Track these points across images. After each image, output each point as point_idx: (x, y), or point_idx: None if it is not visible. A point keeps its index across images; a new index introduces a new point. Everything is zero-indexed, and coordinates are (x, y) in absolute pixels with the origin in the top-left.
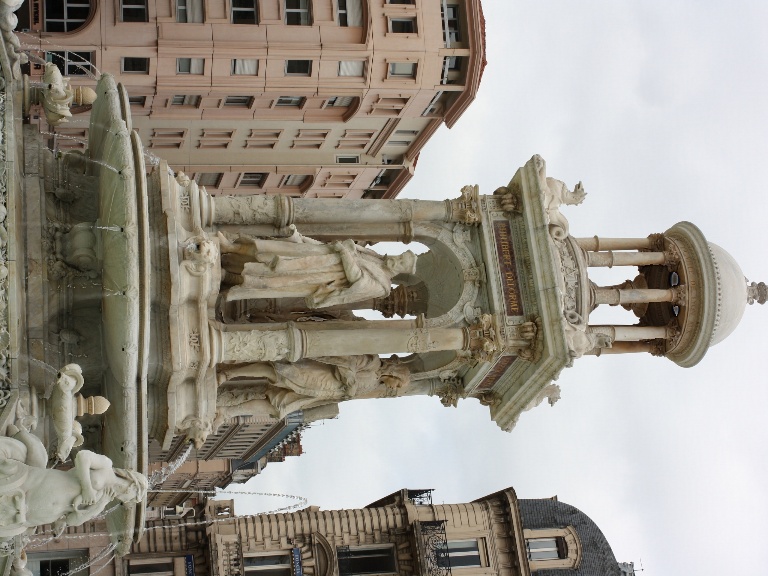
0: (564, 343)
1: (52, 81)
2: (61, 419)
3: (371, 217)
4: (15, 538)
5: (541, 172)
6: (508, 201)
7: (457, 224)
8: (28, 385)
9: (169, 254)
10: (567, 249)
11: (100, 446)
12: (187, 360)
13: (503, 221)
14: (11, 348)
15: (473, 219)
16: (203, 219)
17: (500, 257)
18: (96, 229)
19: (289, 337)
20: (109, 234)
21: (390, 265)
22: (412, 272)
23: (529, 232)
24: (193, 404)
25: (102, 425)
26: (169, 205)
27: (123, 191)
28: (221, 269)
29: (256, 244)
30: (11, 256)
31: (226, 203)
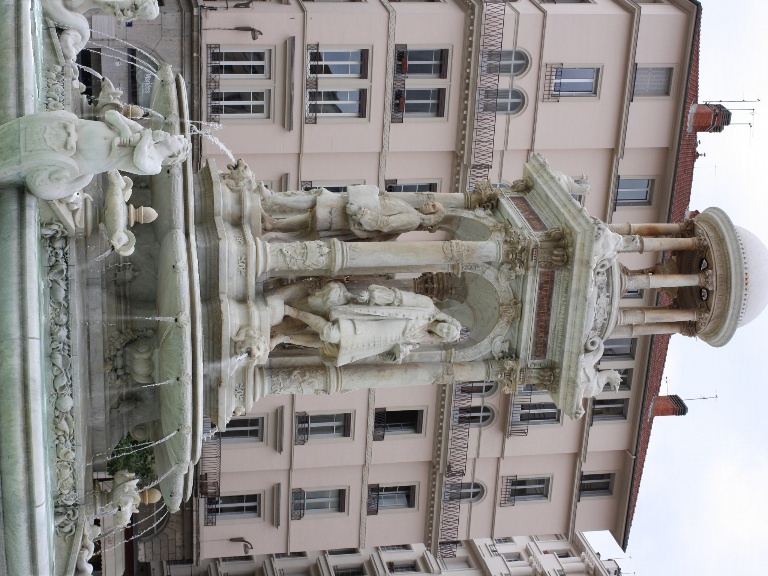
0: None
1: None
2: None
3: None
4: (65, 94)
5: None
6: None
7: None
8: None
9: None
10: None
11: None
12: None
13: None
14: None
15: None
16: None
17: None
18: None
19: None
20: None
21: None
22: None
23: None
24: None
25: None
26: None
27: None
28: None
29: None
30: None
31: None
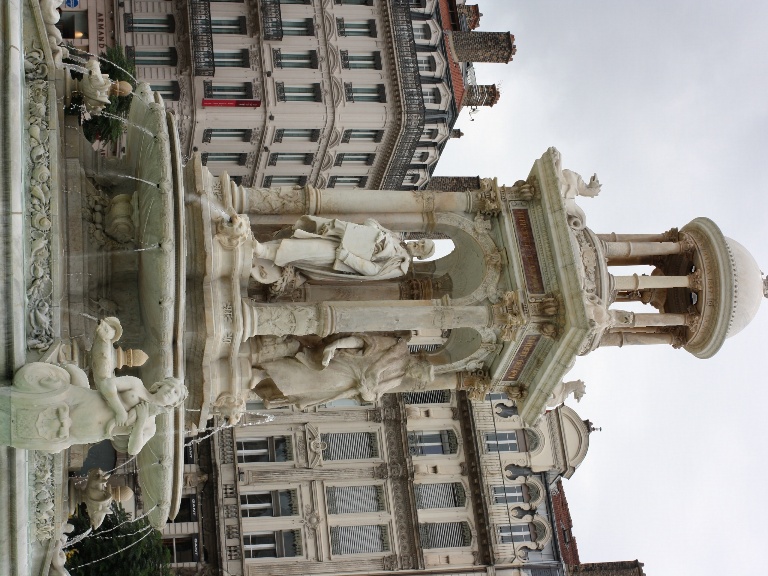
0: (534, 420)
1: None
2: None
3: None
4: None
5: None
6: (547, 334)
7: None
8: (68, 498)
9: (200, 419)
10: None
11: None
12: None
13: (536, 335)
14: None
15: None
16: None
17: (518, 353)
18: None
19: None
20: None
21: None
22: None
23: (551, 360)
24: None
25: None
26: None
27: (159, 515)
28: None
29: None
30: (57, 521)
31: (268, 332)
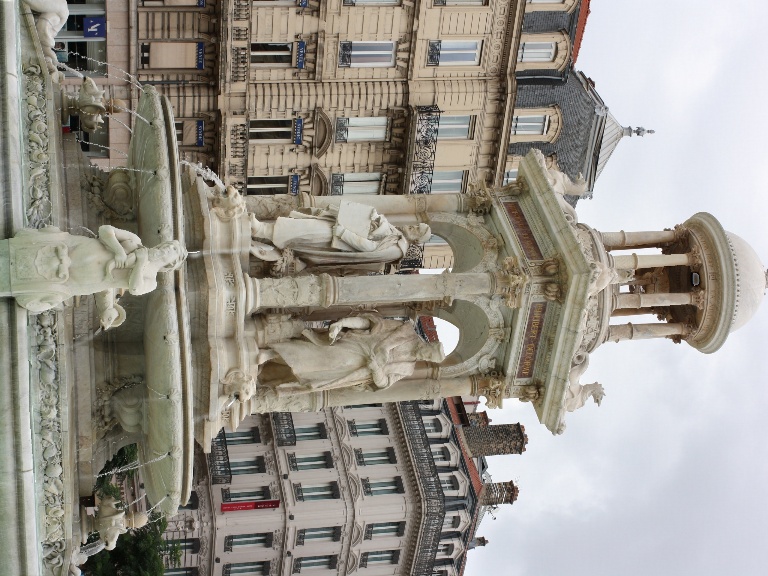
0: (556, 422)
1: (105, 305)
2: None
3: None
4: None
5: None
6: (552, 294)
7: (497, 294)
8: (79, 520)
9: (210, 399)
10: (598, 305)
11: None
12: None
13: (542, 302)
14: None
15: None
16: None
17: (527, 332)
18: (143, 409)
19: (312, 404)
20: None
21: None
22: None
23: (561, 329)
24: None
25: None
26: None
27: (171, 470)
28: (258, 372)
29: (293, 372)
30: (67, 501)
31: (272, 299)
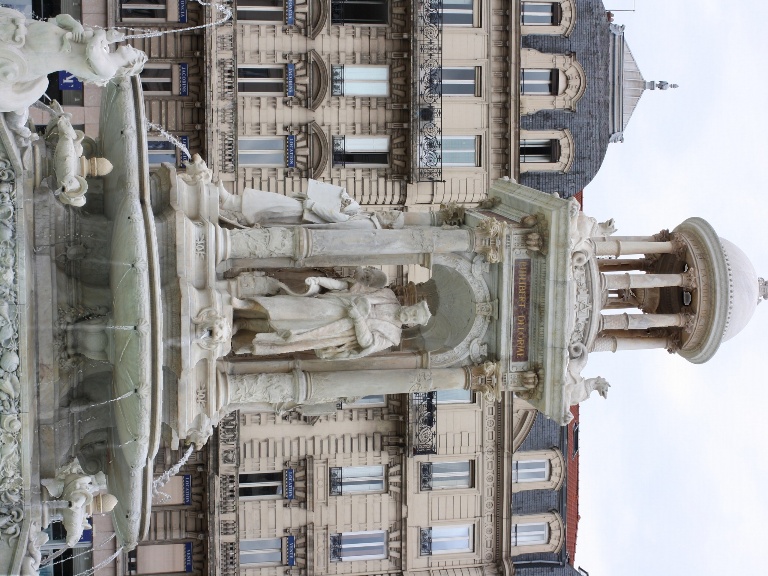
0: (561, 407)
1: (65, 171)
2: (71, 531)
3: (391, 252)
4: None
5: (573, 216)
6: (534, 243)
7: (478, 255)
8: (40, 491)
9: (181, 338)
10: (585, 278)
11: (105, 459)
12: (193, 418)
13: (525, 259)
14: (24, 485)
15: (494, 261)
16: (218, 262)
17: (515, 299)
18: (108, 330)
19: (294, 388)
20: (122, 369)
21: (403, 320)
22: (424, 325)
23: (549, 283)
24: (196, 422)
25: (108, 452)
26: (184, 261)
27: (138, 350)
28: (232, 328)
29: (270, 315)
30: (24, 408)
31: (243, 243)
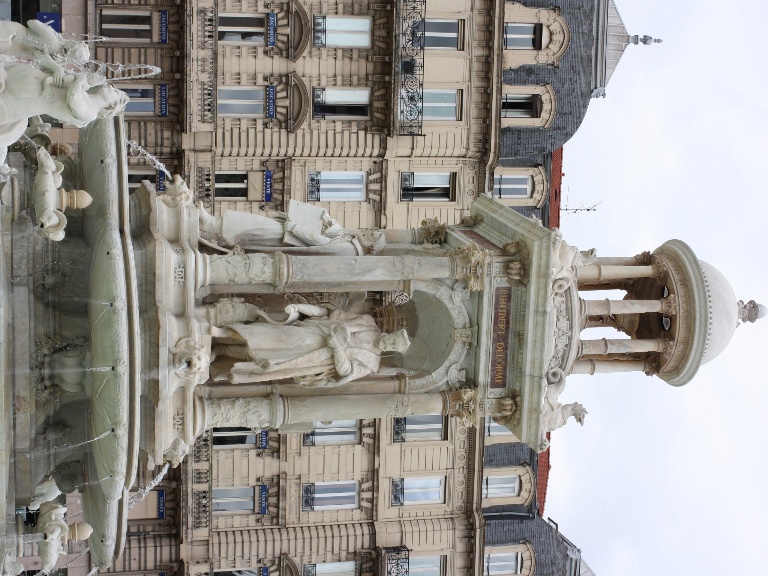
0: (538, 435)
1: (44, 206)
2: (46, 561)
3: (371, 280)
4: None
5: (555, 247)
6: (515, 272)
7: (459, 282)
8: (15, 521)
9: (159, 368)
10: (565, 304)
11: (81, 478)
12: None
13: (506, 287)
14: None
15: (475, 290)
16: (197, 288)
17: (495, 327)
18: (86, 362)
19: (272, 413)
20: (99, 406)
21: (382, 348)
22: None
23: (529, 312)
24: (173, 443)
25: None
26: (163, 289)
27: (116, 391)
28: (211, 356)
29: (248, 344)
30: None
31: (222, 271)
